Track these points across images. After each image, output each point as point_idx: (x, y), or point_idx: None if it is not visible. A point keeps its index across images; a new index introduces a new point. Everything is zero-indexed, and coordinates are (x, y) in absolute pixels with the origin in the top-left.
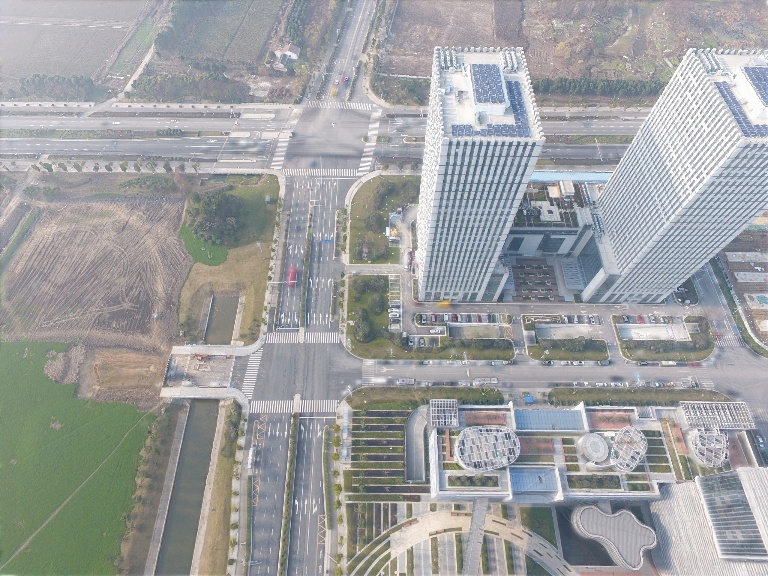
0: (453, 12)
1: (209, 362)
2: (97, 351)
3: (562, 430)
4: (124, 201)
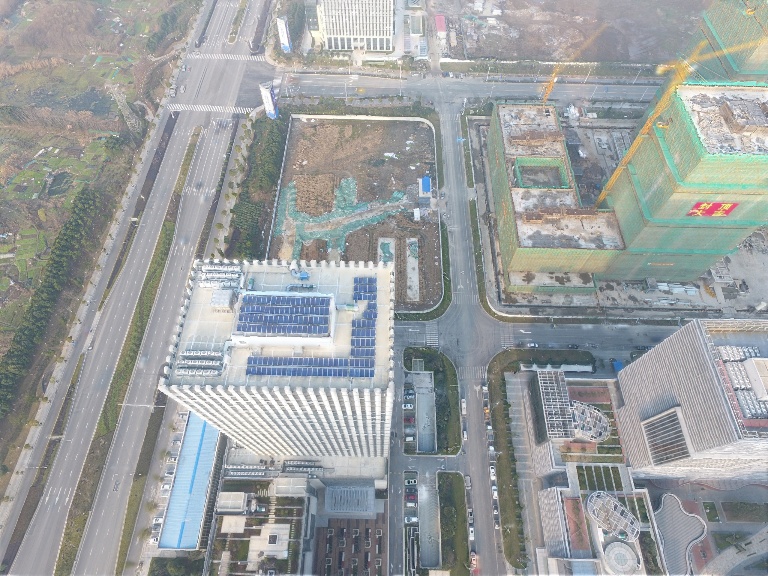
0: None
1: None
2: None
3: None
4: None
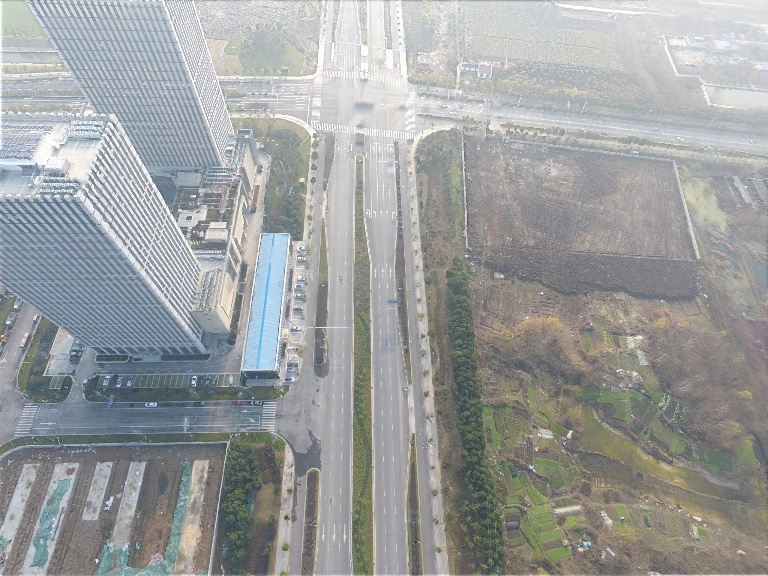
0: (614, 209)
1: None
2: None
3: None
4: (291, 4)
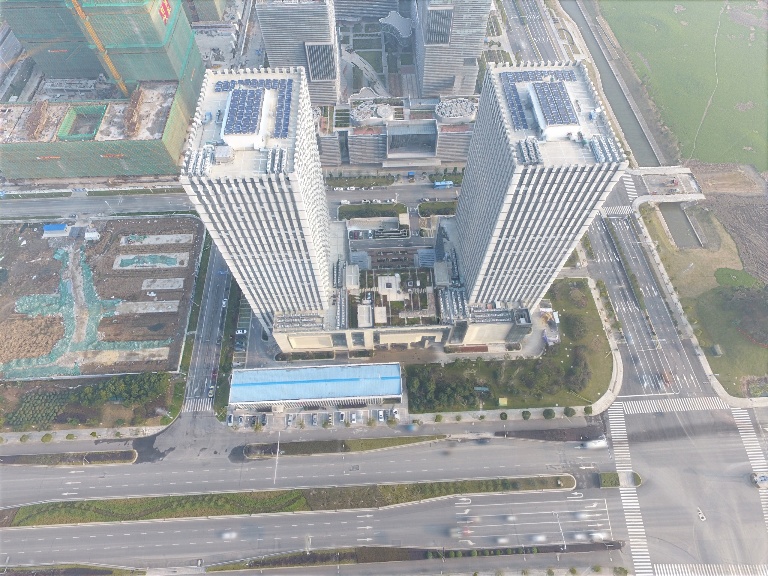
0: None
1: (668, 190)
2: (764, 193)
3: (405, 120)
4: None
